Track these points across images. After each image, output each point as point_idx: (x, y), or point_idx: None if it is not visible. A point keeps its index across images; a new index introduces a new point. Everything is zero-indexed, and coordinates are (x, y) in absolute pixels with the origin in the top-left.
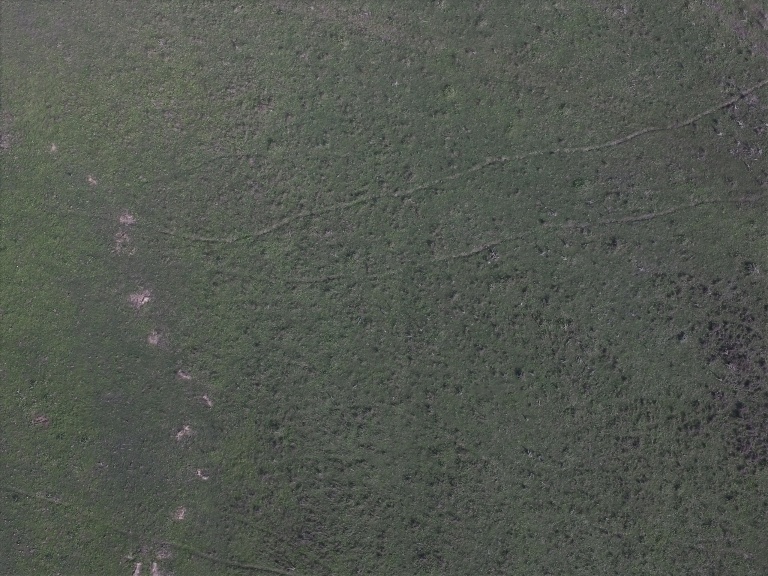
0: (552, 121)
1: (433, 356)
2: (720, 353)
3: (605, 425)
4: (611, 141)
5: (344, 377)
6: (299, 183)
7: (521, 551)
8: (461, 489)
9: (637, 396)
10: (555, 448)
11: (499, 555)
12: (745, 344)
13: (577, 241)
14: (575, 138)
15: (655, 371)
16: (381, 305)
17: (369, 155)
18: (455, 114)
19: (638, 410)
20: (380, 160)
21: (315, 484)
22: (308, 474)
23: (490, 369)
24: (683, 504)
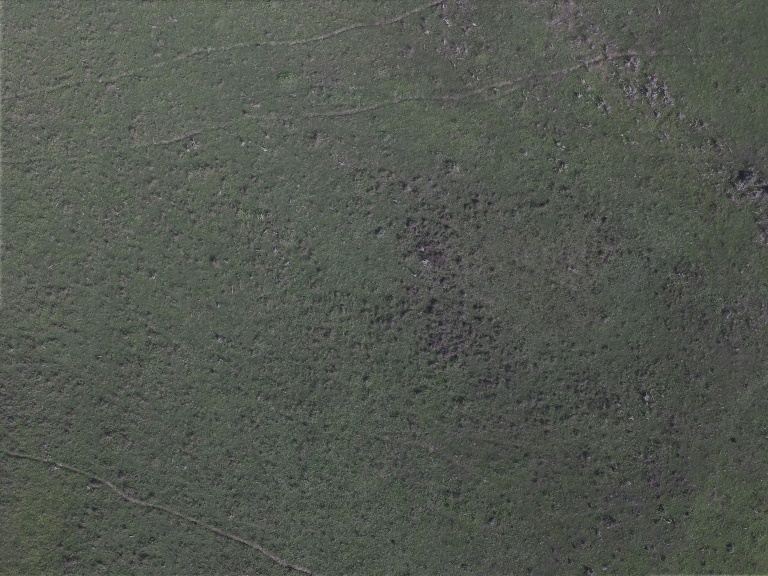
0: (259, 14)
1: (128, 240)
2: (416, 249)
3: (298, 315)
4: (318, 36)
5: (40, 257)
6: (5, 65)
7: (207, 434)
8: (150, 371)
9: (332, 288)
10: (246, 335)
11: (185, 437)
12: (443, 242)
13: (279, 133)
14: (282, 31)
15: (351, 265)
16: (80, 188)
17: (75, 40)
18: (163, 3)
19: (332, 302)
20: (86, 46)
21: (8, 360)
22: (2, 350)
23: (184, 255)
24: (371, 396)
